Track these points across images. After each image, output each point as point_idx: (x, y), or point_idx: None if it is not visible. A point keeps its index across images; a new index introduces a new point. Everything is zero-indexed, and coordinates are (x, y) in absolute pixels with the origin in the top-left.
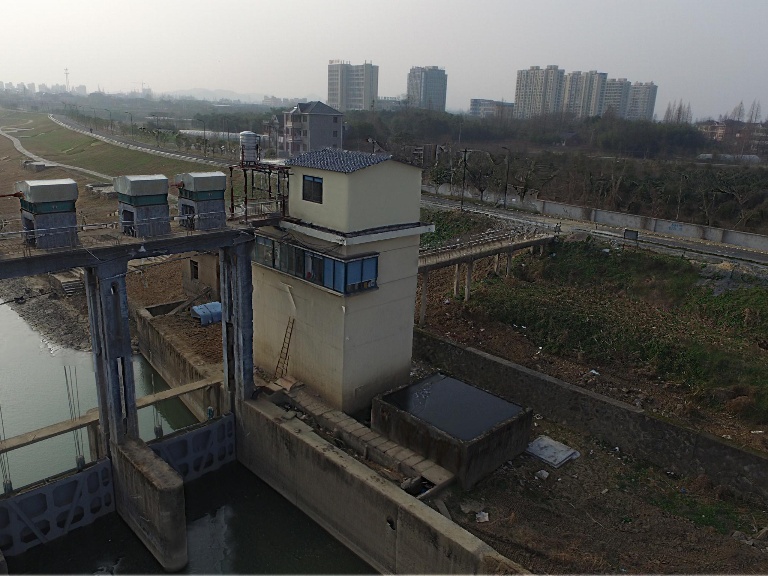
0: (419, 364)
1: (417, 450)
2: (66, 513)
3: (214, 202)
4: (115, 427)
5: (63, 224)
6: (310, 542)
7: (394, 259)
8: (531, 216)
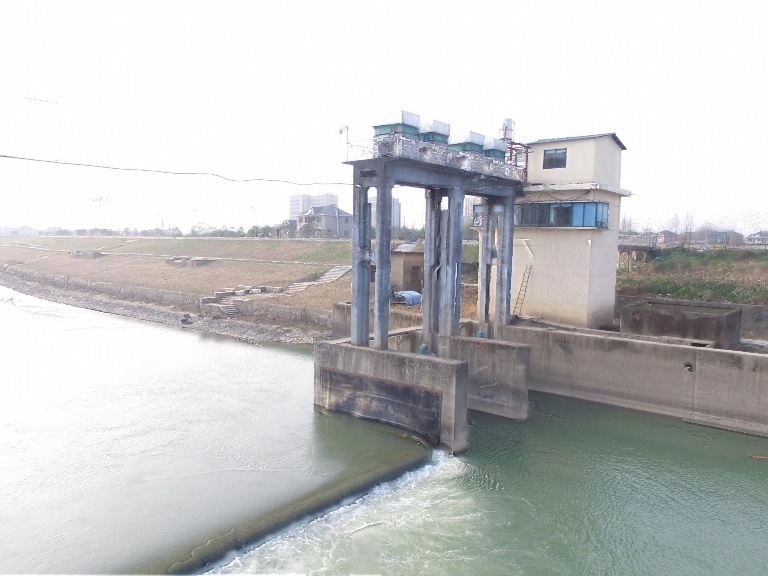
0: None
1: (673, 335)
2: None
3: (502, 159)
4: (450, 321)
5: None
6: None
7: (610, 213)
8: None
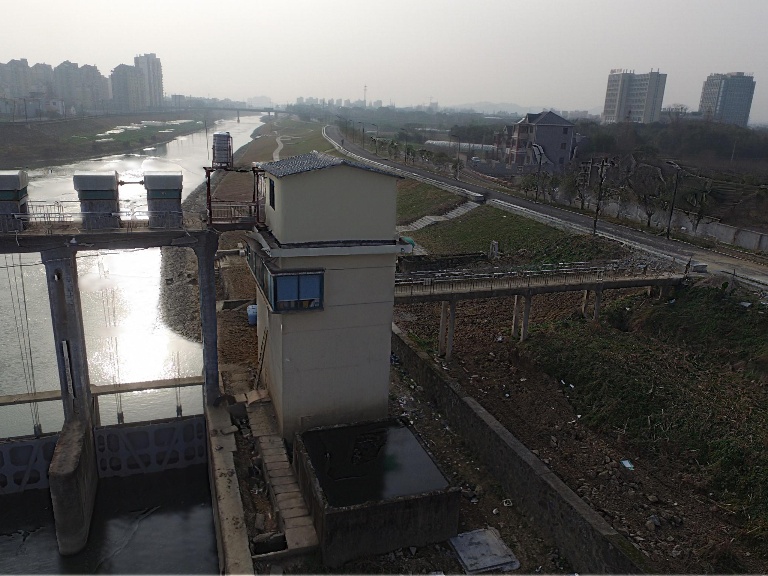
0: (422, 405)
1: (307, 502)
2: (23, 473)
3: (167, 201)
4: None
5: (5, 211)
6: (203, 568)
7: (355, 279)
8: (691, 250)
